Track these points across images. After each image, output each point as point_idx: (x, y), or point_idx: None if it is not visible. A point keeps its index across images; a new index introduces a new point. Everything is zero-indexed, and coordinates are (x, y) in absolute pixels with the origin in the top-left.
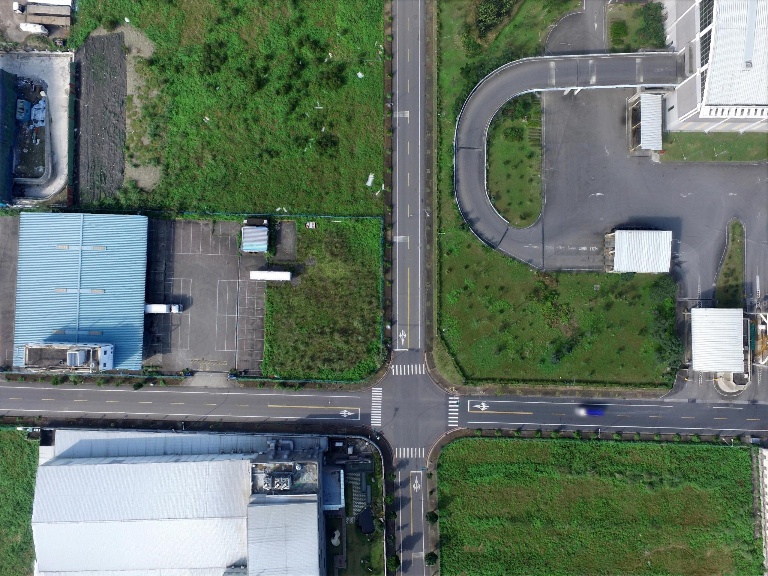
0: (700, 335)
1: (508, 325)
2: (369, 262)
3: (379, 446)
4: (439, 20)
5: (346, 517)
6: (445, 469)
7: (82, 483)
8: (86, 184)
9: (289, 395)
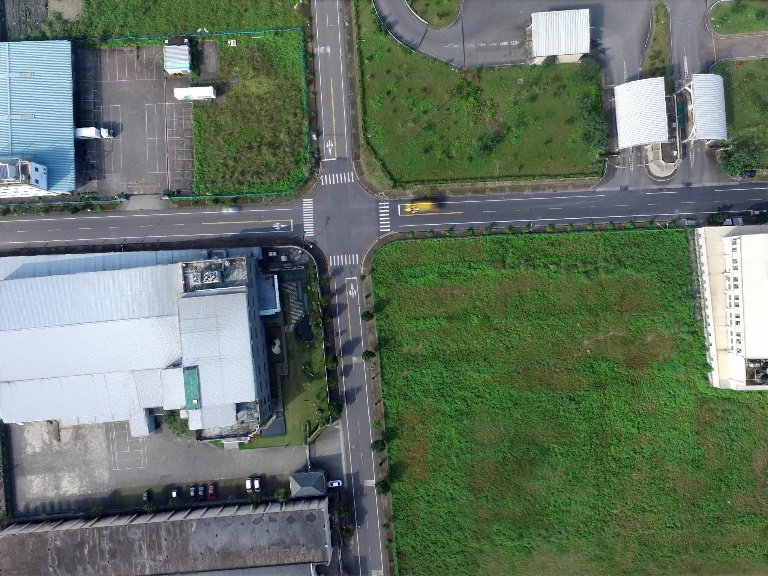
0: (623, 111)
1: (433, 126)
2: (291, 75)
3: (313, 255)
4: None
5: (285, 325)
6: (379, 273)
7: (23, 294)
8: (12, 20)
9: (222, 212)
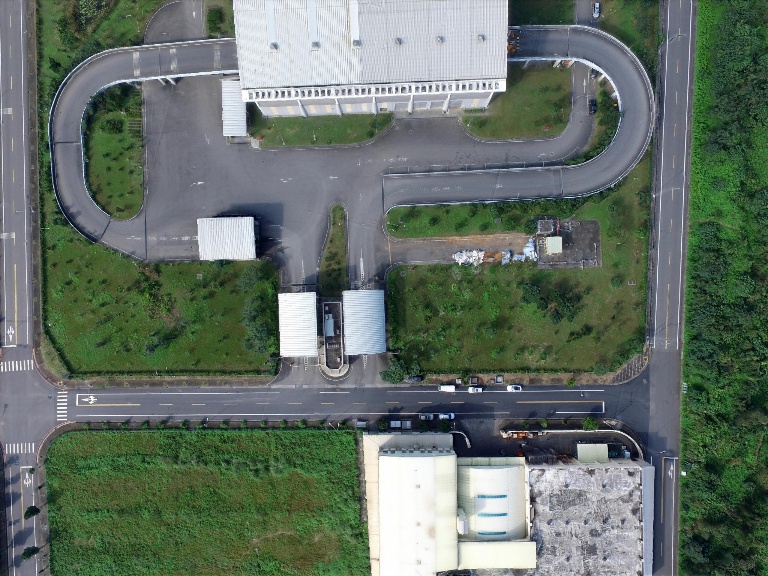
0: (283, 320)
1: (111, 318)
2: None
3: None
4: (38, 15)
5: None
6: (53, 463)
7: None
8: None
9: None
